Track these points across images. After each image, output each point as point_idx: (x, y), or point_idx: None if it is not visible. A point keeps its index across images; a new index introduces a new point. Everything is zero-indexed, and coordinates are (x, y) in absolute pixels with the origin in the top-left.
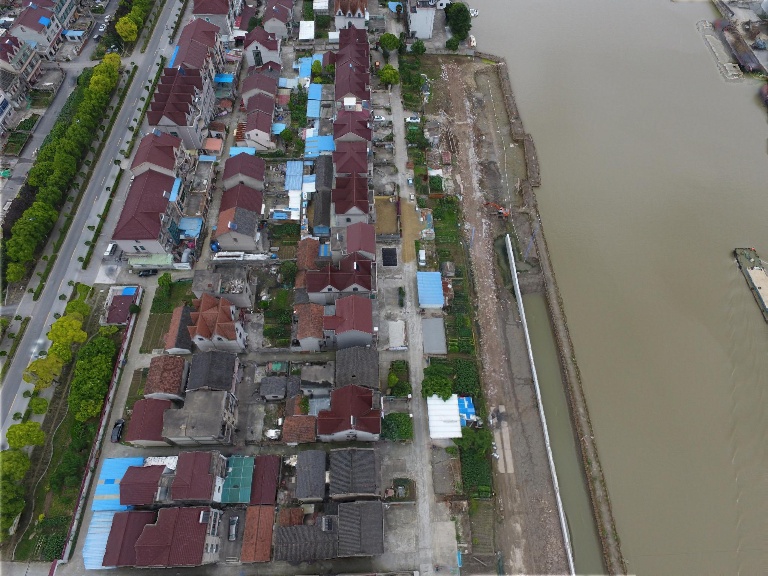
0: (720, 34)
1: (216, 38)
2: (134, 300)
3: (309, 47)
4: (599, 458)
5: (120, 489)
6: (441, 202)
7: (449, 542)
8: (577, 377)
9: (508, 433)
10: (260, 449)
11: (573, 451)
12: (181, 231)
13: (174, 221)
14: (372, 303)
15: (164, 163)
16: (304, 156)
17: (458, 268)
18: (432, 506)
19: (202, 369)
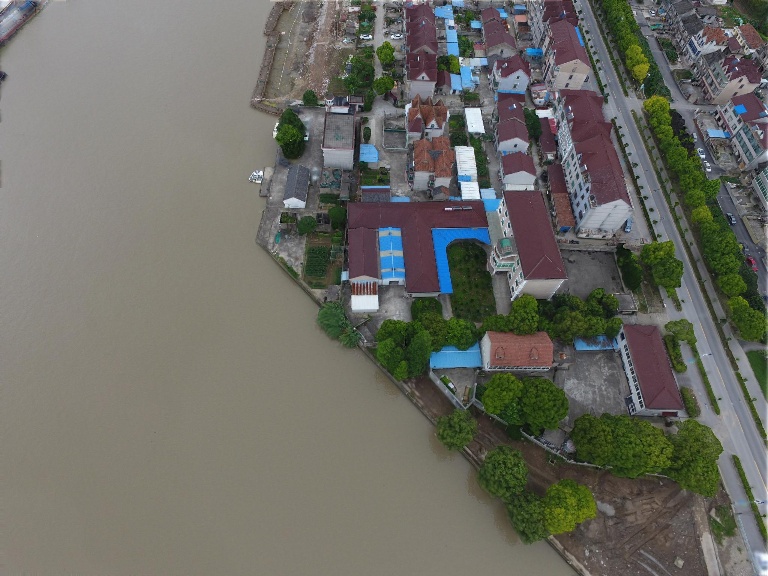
0: None
1: None
2: None
3: None
4: None
5: None
6: None
7: None
8: None
9: None
10: None
11: None
12: None
13: None
14: None
15: None
16: None
17: None
18: None
19: None
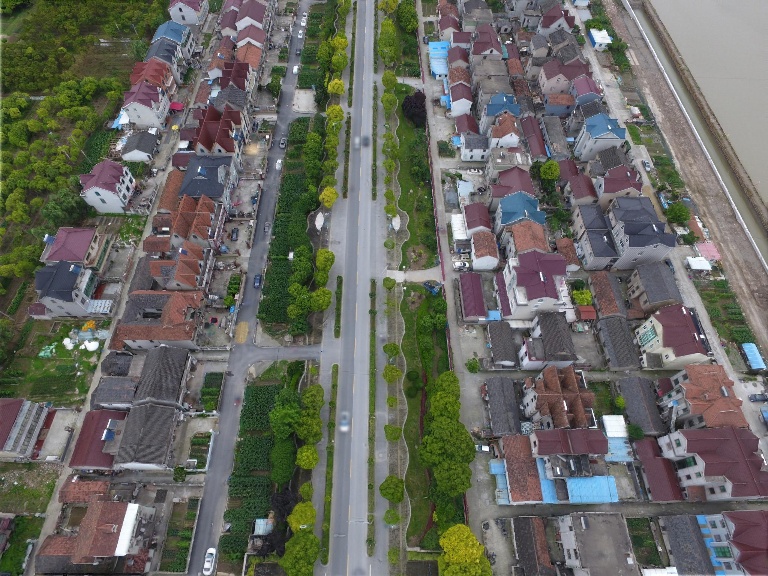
0: None
1: None
2: None
3: None
4: None
5: (453, 35)
6: None
7: (612, 79)
8: (669, 36)
9: (634, 53)
10: None
11: (669, 65)
12: None
13: None
14: None
15: None
16: None
17: None
18: (600, 68)
19: (473, 5)
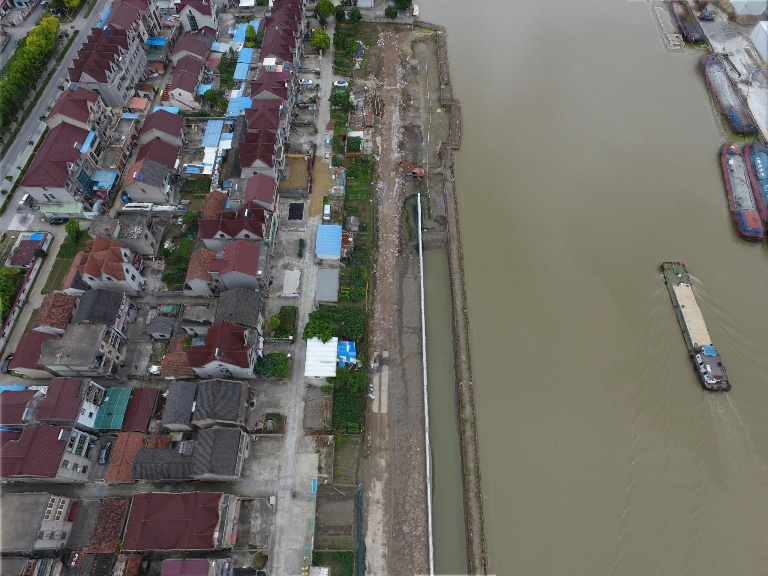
0: (669, 6)
1: (149, 2)
2: (41, 245)
3: (249, 14)
4: (475, 402)
5: None
6: (356, 161)
7: (310, 472)
8: (465, 327)
9: (387, 376)
10: (142, 383)
11: (452, 396)
12: (95, 183)
13: (87, 173)
14: (260, 249)
15: (77, 116)
16: (225, 115)
17: (364, 223)
18: (299, 439)
19: (87, 305)
